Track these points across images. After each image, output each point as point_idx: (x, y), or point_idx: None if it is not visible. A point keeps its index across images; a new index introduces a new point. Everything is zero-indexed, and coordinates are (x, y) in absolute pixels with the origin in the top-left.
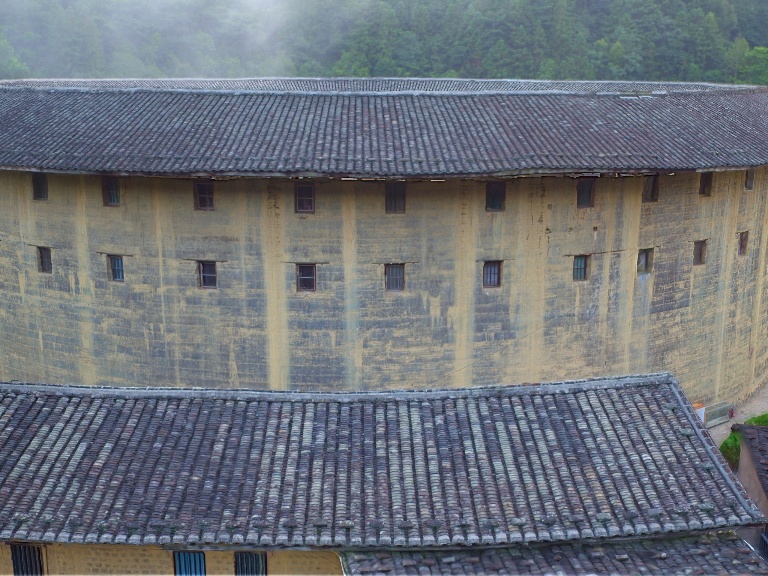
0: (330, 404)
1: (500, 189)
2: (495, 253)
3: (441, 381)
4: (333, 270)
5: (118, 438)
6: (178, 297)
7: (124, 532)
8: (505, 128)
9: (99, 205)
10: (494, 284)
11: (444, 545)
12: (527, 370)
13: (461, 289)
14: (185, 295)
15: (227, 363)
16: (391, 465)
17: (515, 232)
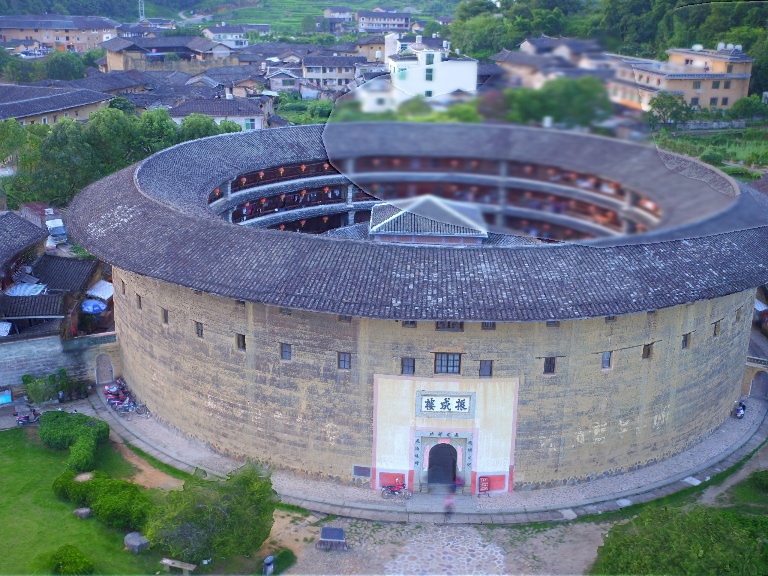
0: None
1: None
2: None
3: None
4: None
5: None
6: None
7: None
8: None
9: None
10: None
11: None
12: None
13: None
14: None
15: None
16: None
17: None
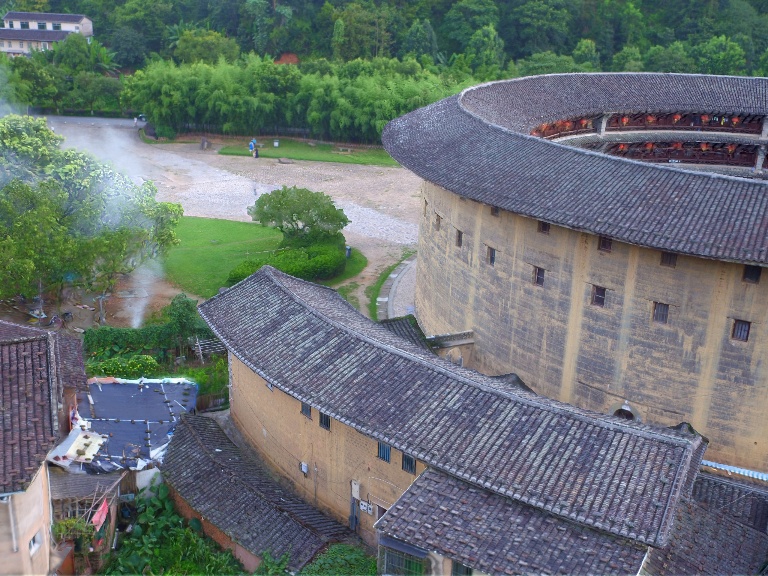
0: (476, 389)
1: (757, 266)
2: (745, 315)
3: (684, 399)
4: (617, 296)
5: (371, 371)
6: (520, 287)
7: (346, 417)
8: (764, 220)
9: (489, 213)
10: (743, 338)
11: (472, 482)
12: (760, 413)
13: (711, 335)
14: (524, 286)
15: (541, 340)
16: (479, 433)
17: (765, 302)
